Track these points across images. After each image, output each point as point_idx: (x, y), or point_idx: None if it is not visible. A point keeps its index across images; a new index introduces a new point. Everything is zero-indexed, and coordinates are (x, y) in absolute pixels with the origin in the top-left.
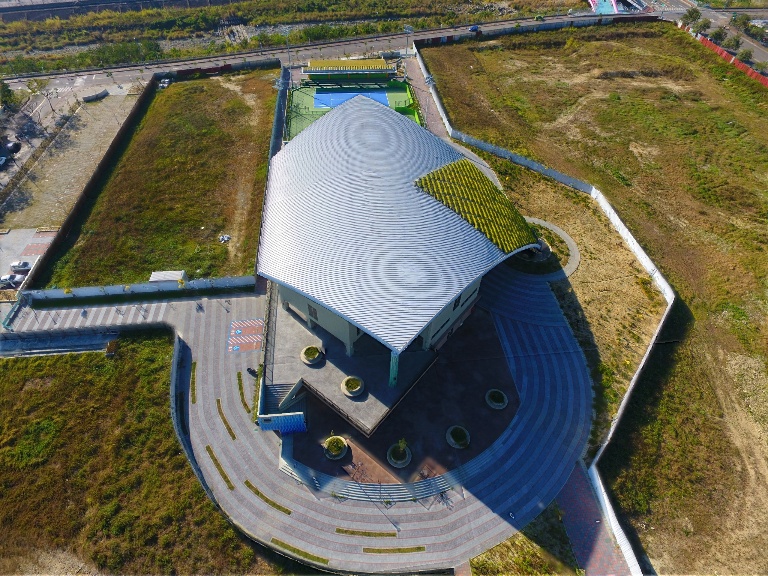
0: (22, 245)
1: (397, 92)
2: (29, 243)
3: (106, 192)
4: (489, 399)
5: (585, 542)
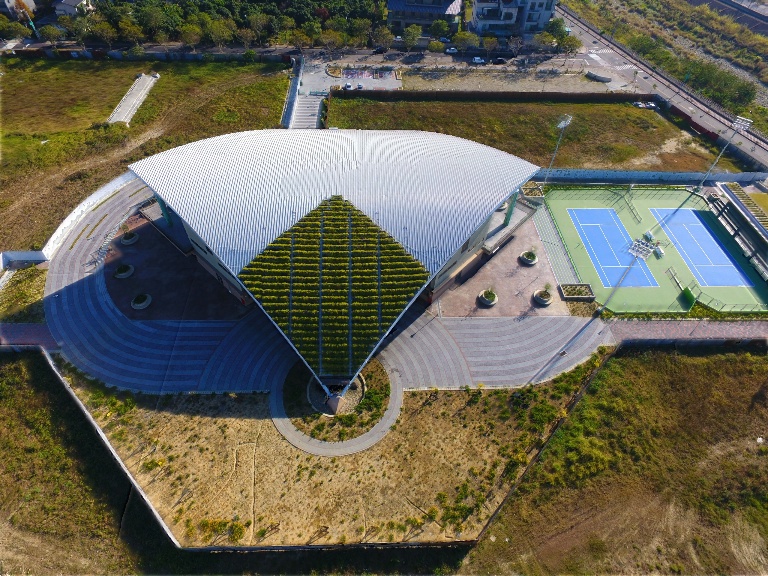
0: (384, 86)
1: (761, 300)
2: (386, 88)
3: (445, 103)
4: (142, 294)
5: (7, 332)
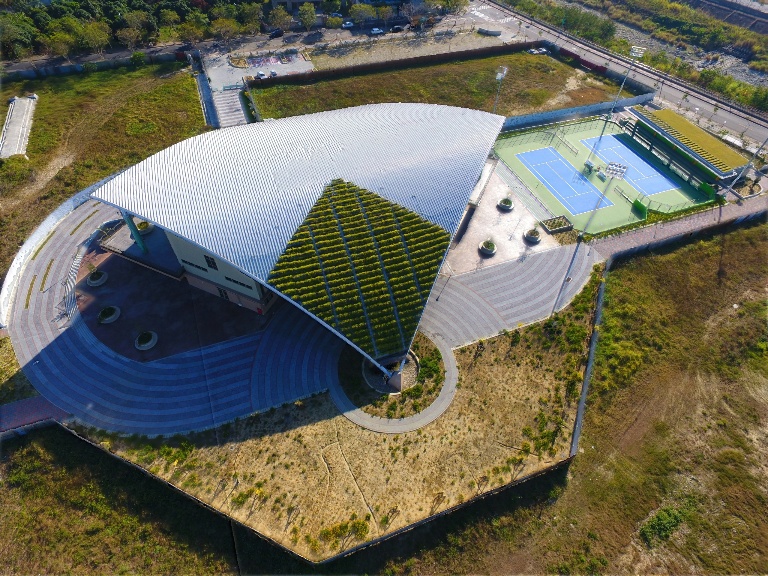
0: (297, 69)
1: (690, 198)
2: (299, 71)
3: (364, 77)
4: None
5: None
